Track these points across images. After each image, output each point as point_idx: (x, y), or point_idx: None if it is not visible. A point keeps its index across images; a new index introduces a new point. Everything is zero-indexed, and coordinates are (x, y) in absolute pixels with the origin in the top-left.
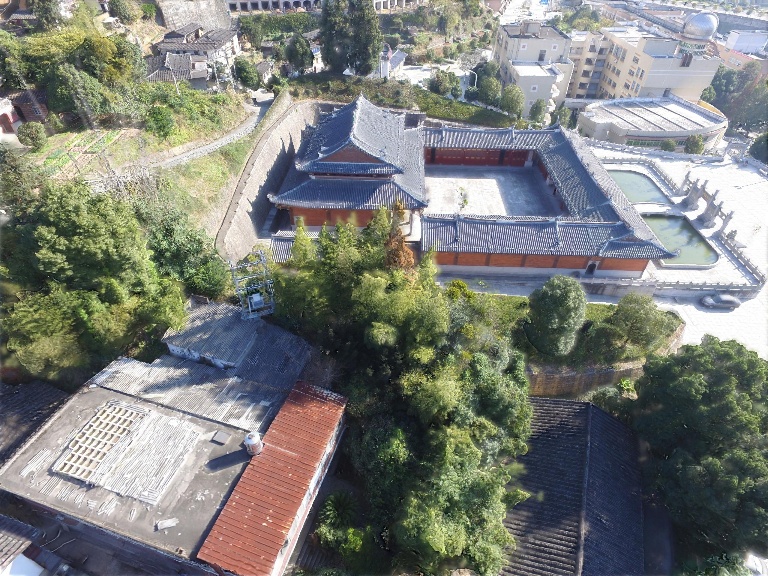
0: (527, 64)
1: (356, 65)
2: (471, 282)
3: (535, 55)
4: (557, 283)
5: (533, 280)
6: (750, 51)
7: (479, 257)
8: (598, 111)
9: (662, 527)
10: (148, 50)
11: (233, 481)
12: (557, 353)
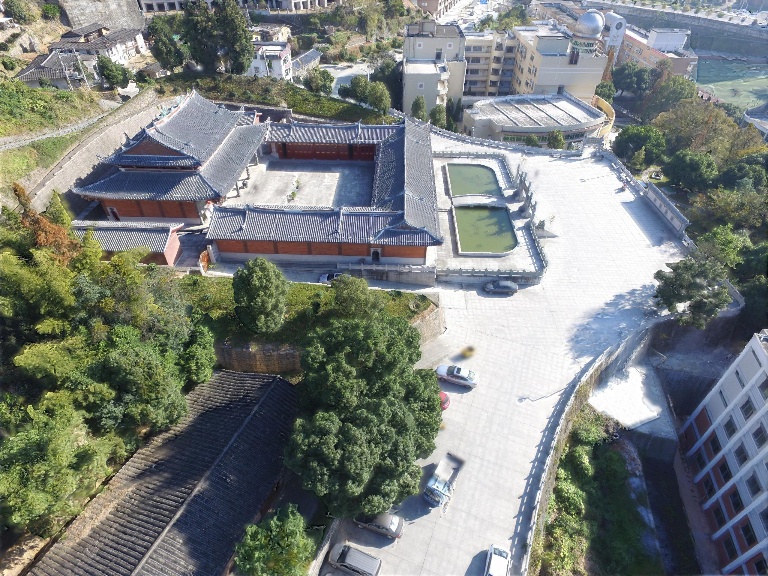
0: (423, 62)
1: (231, 63)
2: None
3: (432, 53)
4: (249, 264)
5: (321, 267)
6: (669, 49)
7: (267, 245)
8: (486, 108)
9: None
10: (45, 49)
11: None
12: (257, 330)
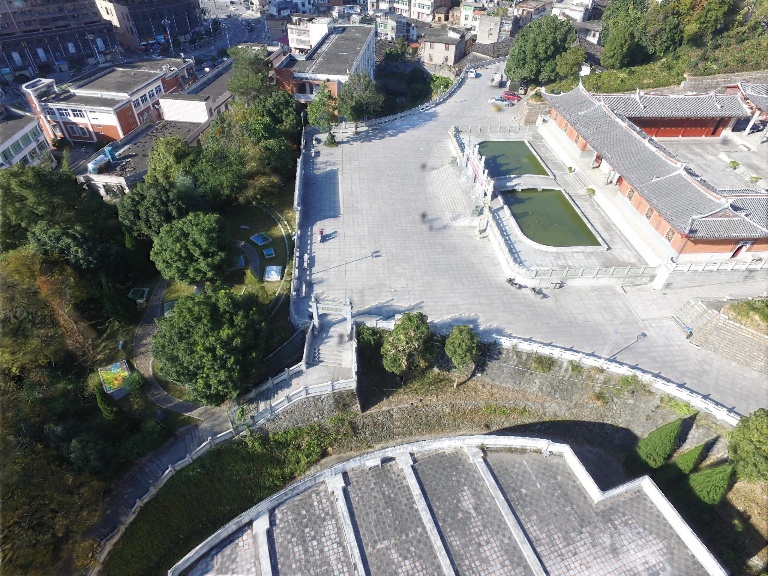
0: None
1: None
2: None
3: None
4: None
5: None
6: None
7: None
8: None
9: None
10: None
11: None
12: None
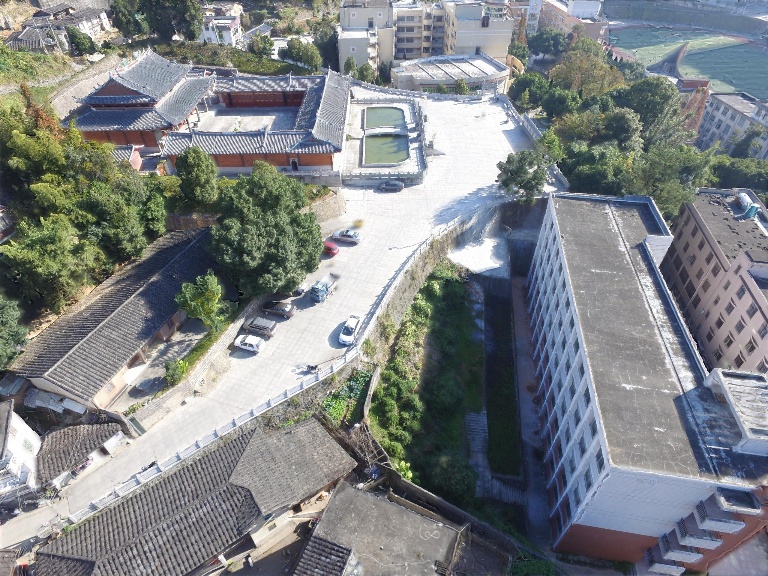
0: (357, 30)
1: (184, 32)
2: None
3: (365, 22)
4: None
5: None
6: (586, 16)
7: None
8: (411, 67)
9: None
10: (18, 27)
11: None
12: (195, 198)
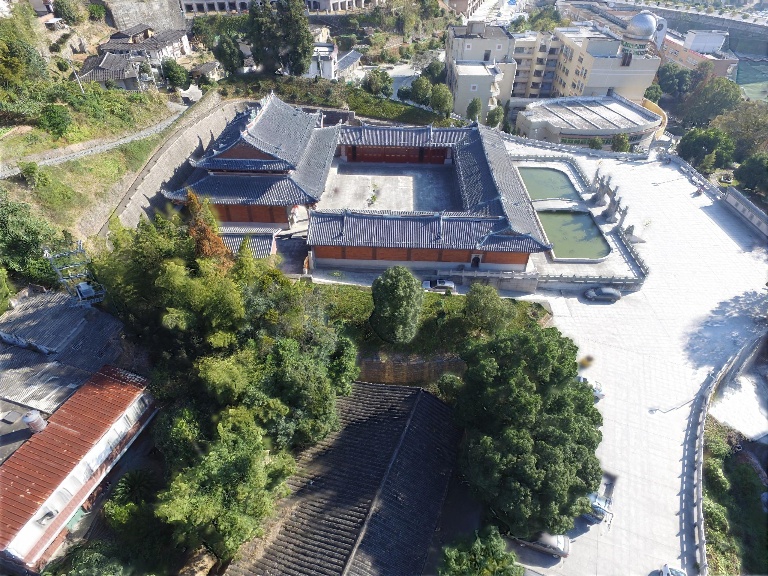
0: (472, 64)
1: (290, 65)
2: (357, 275)
3: (480, 55)
4: (391, 273)
5: (420, 273)
6: (707, 51)
7: (365, 251)
8: (539, 110)
9: (476, 507)
10: (94, 50)
11: (8, 457)
12: (395, 341)
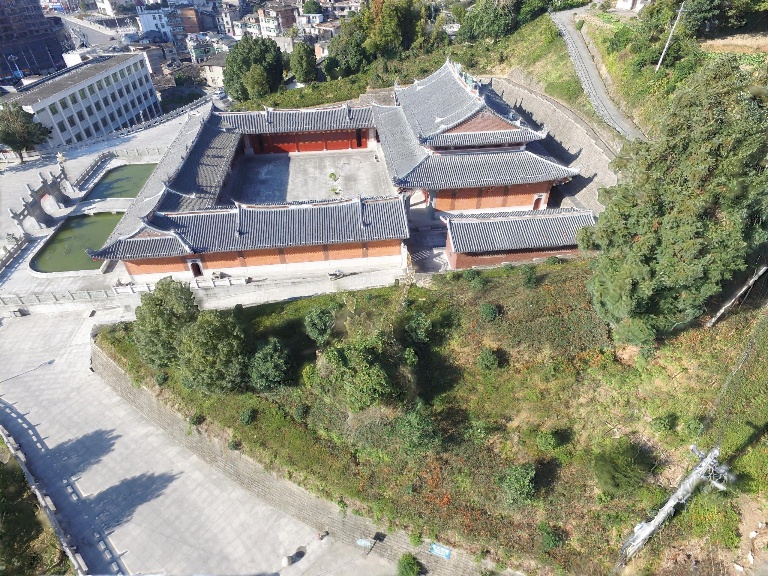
0: None
1: None
2: None
3: None
4: None
5: None
6: None
7: None
8: None
9: None
10: None
11: None
12: None
